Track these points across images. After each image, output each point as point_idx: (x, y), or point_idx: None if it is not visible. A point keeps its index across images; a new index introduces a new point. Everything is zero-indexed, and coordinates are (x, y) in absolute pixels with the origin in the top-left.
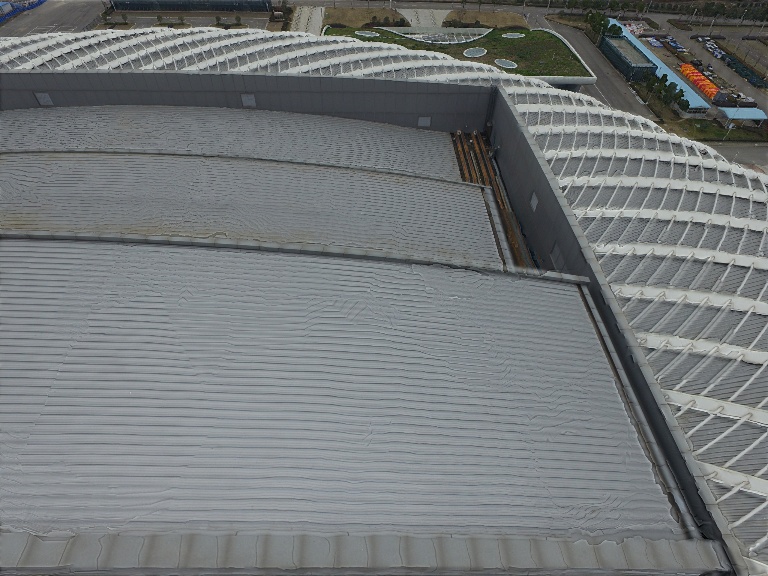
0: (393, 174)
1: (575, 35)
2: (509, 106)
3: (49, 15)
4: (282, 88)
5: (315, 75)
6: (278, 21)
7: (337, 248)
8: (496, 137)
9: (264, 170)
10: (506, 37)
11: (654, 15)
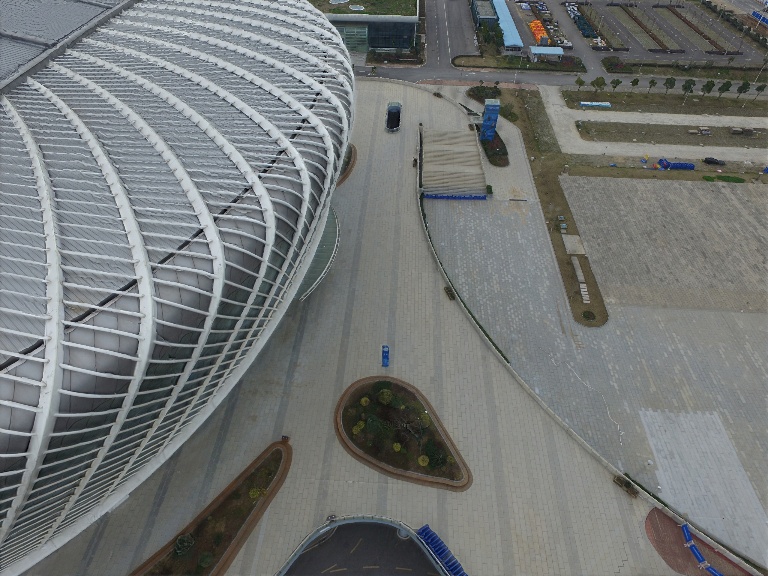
0: None
1: None
2: None
3: None
4: None
5: None
6: None
7: None
8: None
9: None
10: None
11: None
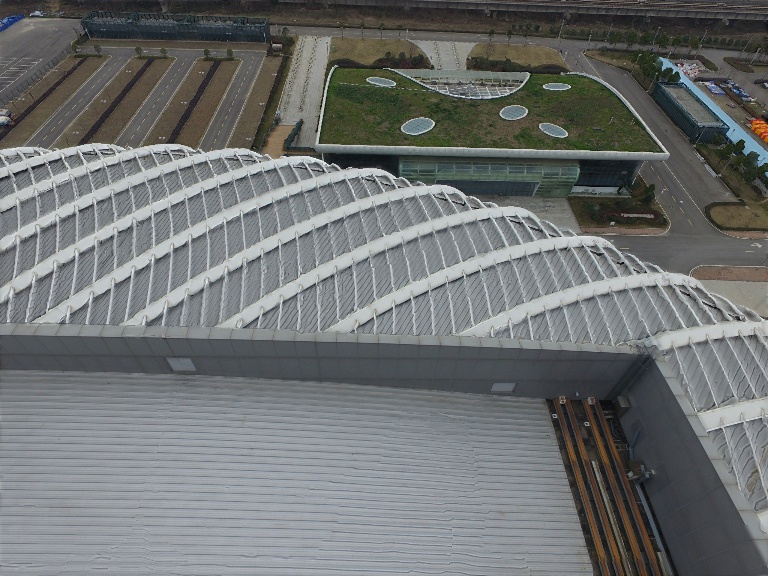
0: None
1: (621, 78)
2: (699, 438)
3: (12, 43)
4: (243, 352)
5: (306, 336)
6: (277, 55)
7: None
8: (644, 443)
9: None
10: (548, 89)
11: (707, 51)
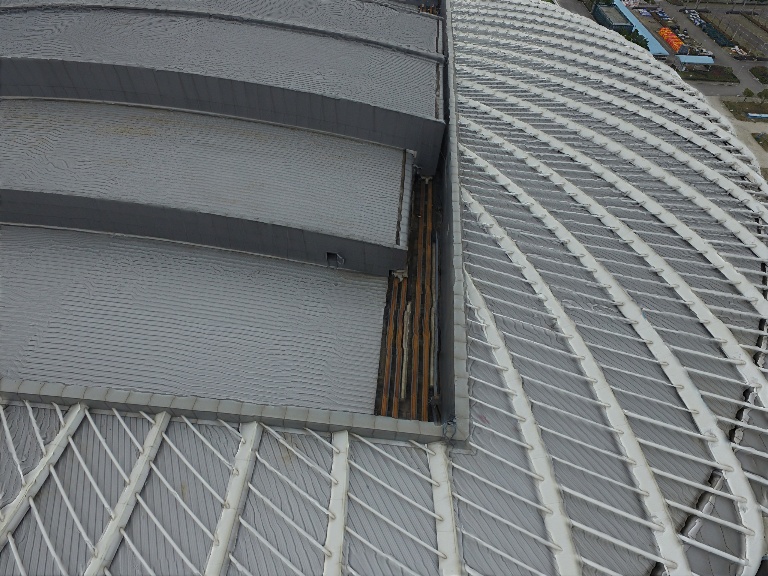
0: None
1: (575, 5)
2: None
3: None
4: None
5: None
6: None
7: None
8: None
9: None
10: None
11: None
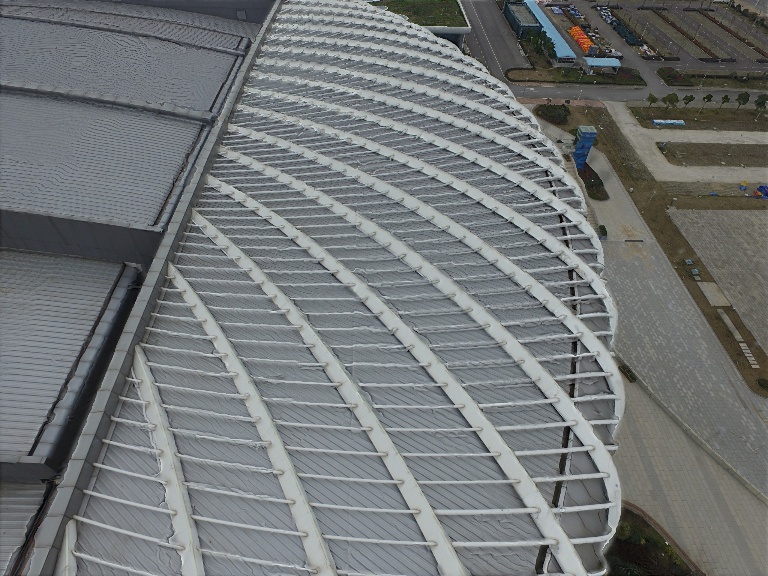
0: (181, 25)
1: (487, 4)
2: None
3: None
4: None
5: None
6: None
7: (93, 23)
8: None
9: (94, 16)
10: None
11: None
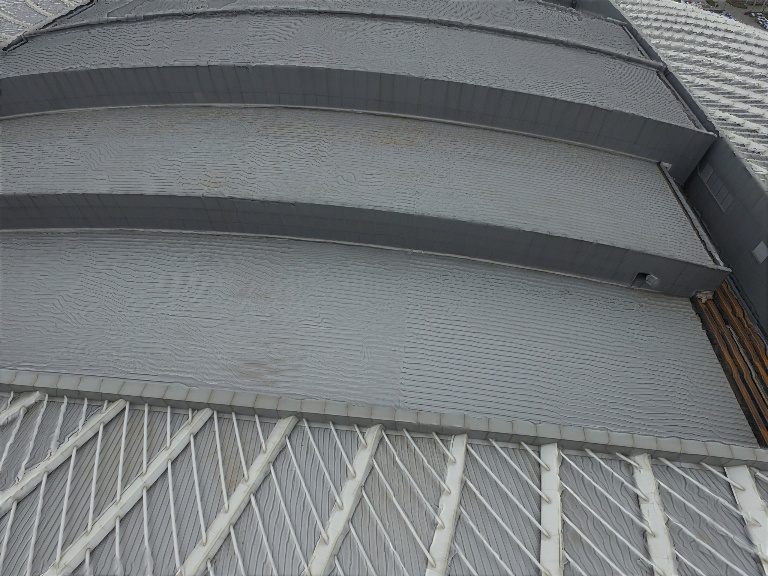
0: None
1: None
2: None
3: None
4: None
5: None
6: None
7: None
8: (579, 7)
9: None
10: None
11: None
